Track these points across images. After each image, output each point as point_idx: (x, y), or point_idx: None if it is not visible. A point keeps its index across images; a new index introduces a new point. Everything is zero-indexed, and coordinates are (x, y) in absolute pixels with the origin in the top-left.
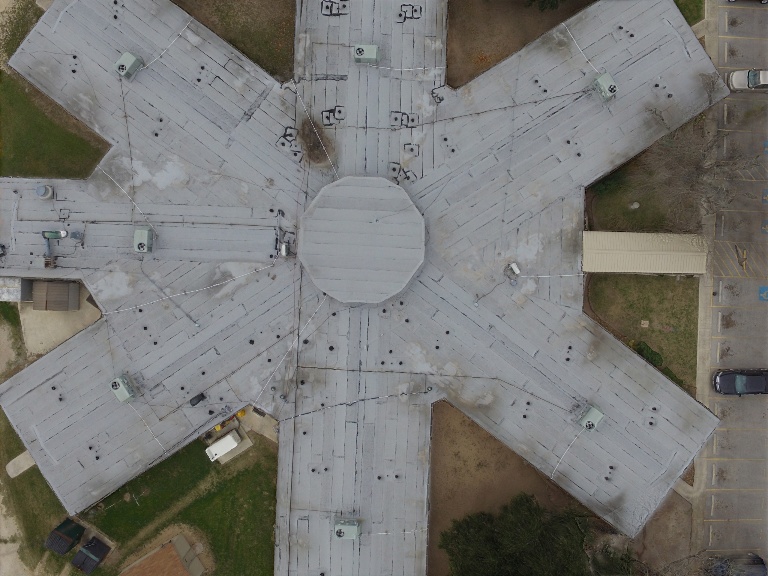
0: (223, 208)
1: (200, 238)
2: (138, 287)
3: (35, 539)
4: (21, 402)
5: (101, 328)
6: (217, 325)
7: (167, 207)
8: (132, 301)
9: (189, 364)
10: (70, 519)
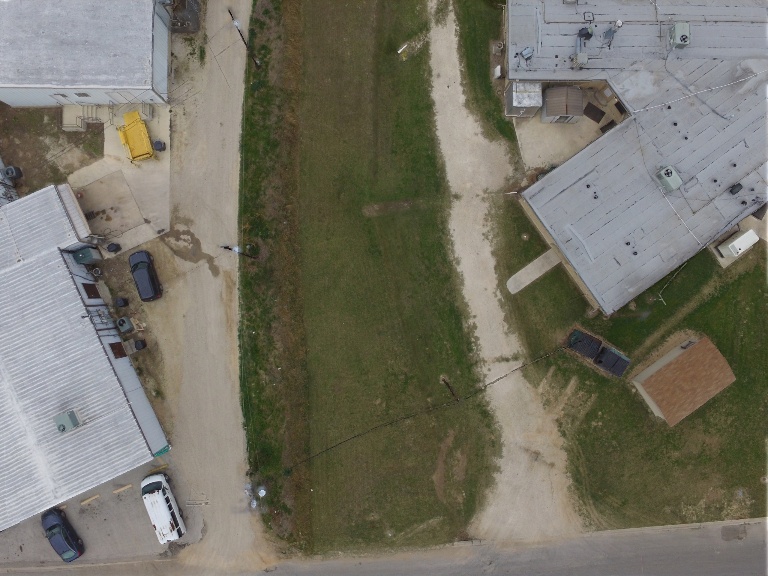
0: (740, 8)
1: (724, 36)
2: (664, 86)
3: (539, 355)
4: (554, 202)
5: (630, 126)
6: (746, 118)
7: (688, 8)
8: (658, 99)
9: (721, 157)
10: (578, 330)
